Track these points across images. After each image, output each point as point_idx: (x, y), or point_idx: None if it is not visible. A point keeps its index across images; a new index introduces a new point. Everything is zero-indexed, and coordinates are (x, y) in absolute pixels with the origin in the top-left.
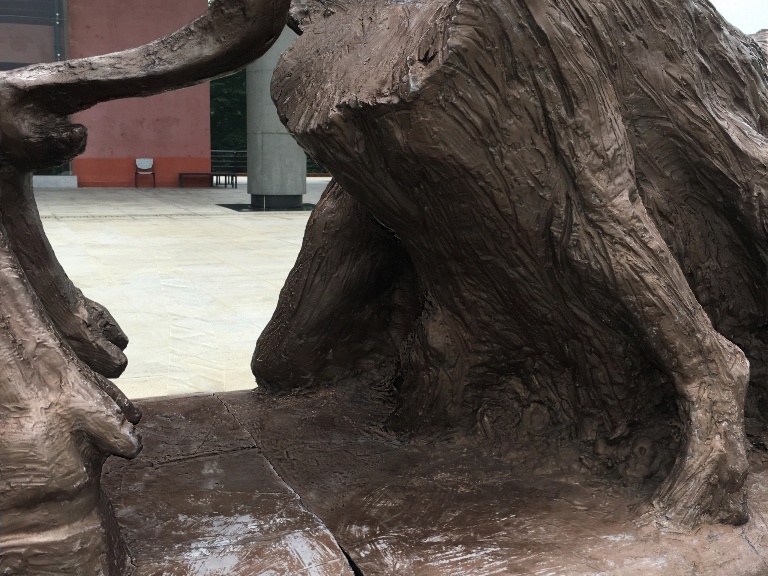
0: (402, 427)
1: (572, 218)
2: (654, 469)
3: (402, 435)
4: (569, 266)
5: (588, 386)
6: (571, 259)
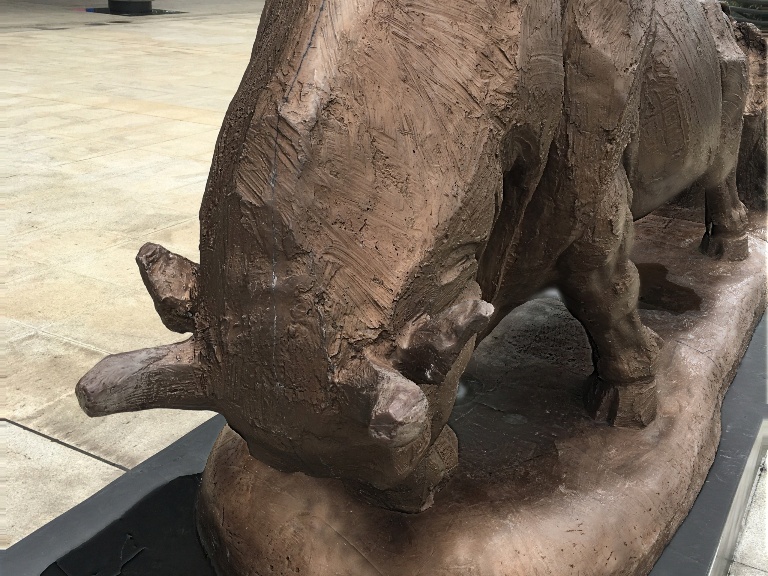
0: (691, 206)
1: (762, 139)
2: (759, 205)
3: (691, 208)
4: (758, 152)
5: (743, 185)
6: (760, 150)
